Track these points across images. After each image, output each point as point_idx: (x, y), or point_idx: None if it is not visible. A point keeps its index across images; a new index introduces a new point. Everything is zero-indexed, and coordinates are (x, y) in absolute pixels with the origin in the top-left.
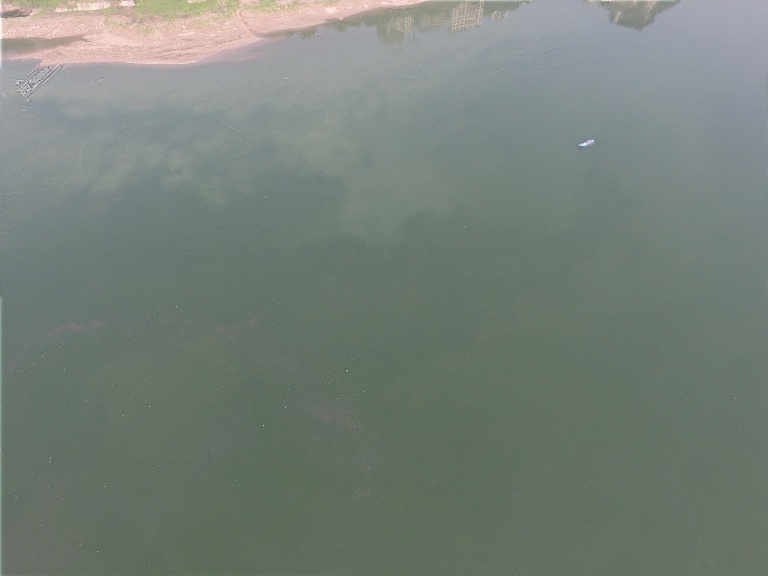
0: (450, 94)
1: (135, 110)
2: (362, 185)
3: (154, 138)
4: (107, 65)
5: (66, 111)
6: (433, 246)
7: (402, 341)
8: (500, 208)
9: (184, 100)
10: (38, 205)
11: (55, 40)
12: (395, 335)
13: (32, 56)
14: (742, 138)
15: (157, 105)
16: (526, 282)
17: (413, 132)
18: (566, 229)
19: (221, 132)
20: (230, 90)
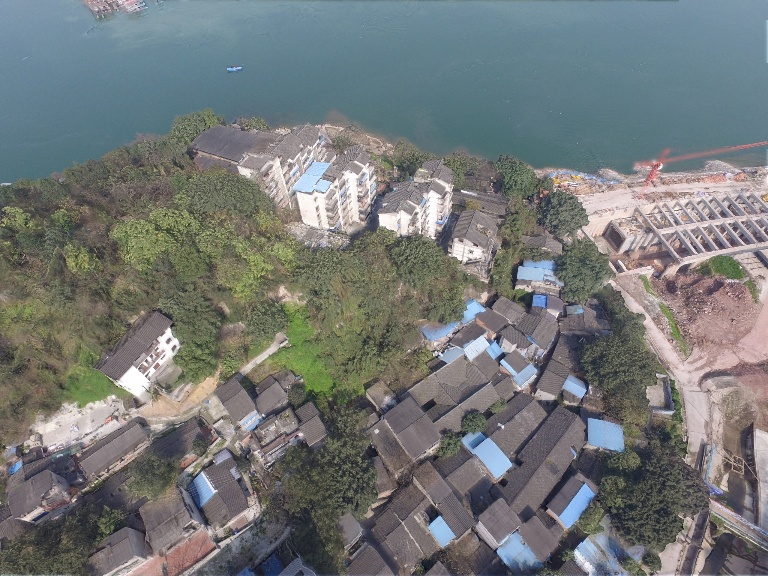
0: None
1: None
2: None
3: None
4: None
5: None
6: (654, 29)
7: (663, 56)
8: (685, 15)
9: None
10: (407, 20)
11: None
12: (658, 54)
13: None
14: None
15: None
16: (718, 38)
17: None
18: (730, 20)
19: None
20: None
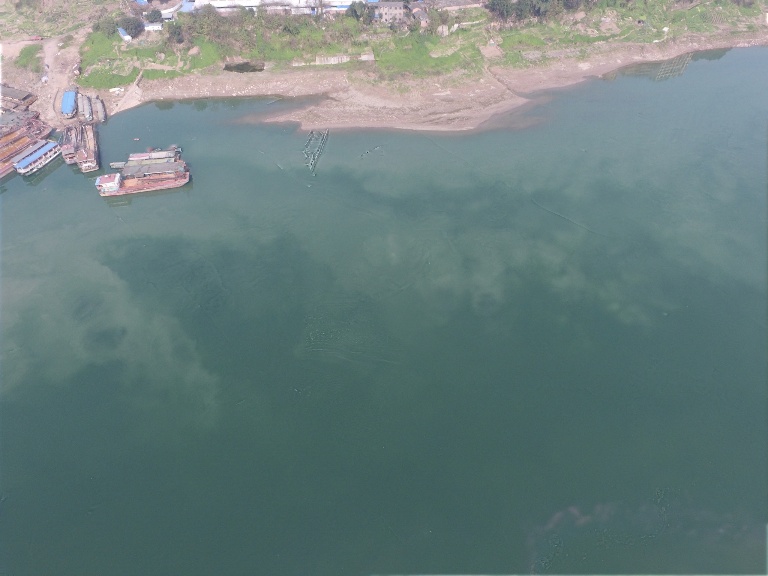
0: None
1: (432, 187)
2: None
3: (478, 226)
4: (375, 130)
5: (358, 188)
6: None
7: None
8: None
9: (480, 175)
10: (400, 319)
11: (300, 98)
12: None
13: (288, 118)
14: None
15: (455, 182)
16: None
17: None
18: None
19: (550, 219)
20: (528, 164)
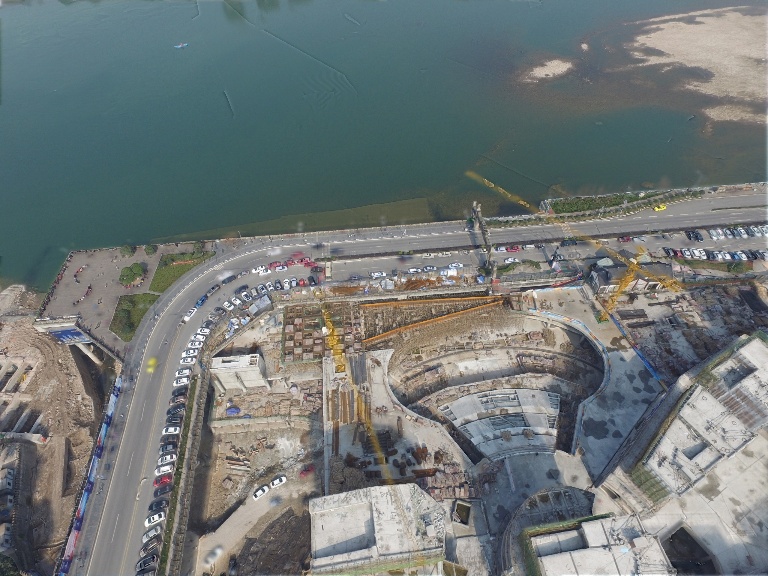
0: (124, 23)
1: None
2: (9, 72)
3: None
4: None
5: None
6: (23, 100)
7: None
8: (88, 81)
9: None
10: None
11: None
12: None
13: None
14: (300, 40)
15: None
16: (60, 113)
17: (77, 45)
18: (117, 89)
19: None
20: None
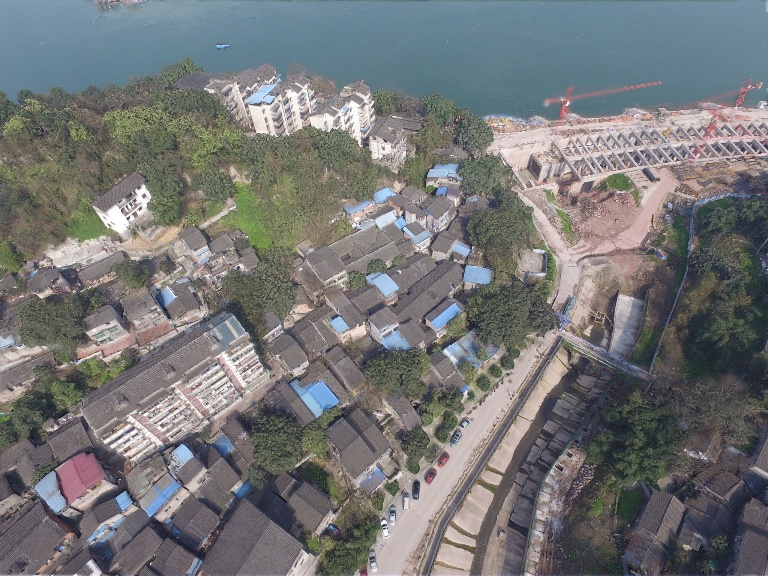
0: None
1: None
2: None
3: None
4: None
5: None
6: (602, 6)
7: None
8: None
9: None
10: (380, 4)
11: None
12: (600, 26)
13: None
14: None
15: None
16: (657, 12)
17: None
18: None
19: None
20: None
